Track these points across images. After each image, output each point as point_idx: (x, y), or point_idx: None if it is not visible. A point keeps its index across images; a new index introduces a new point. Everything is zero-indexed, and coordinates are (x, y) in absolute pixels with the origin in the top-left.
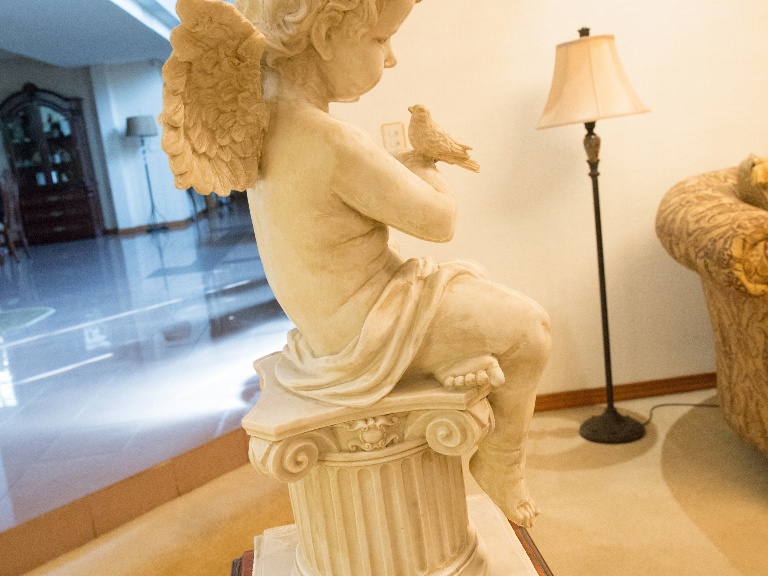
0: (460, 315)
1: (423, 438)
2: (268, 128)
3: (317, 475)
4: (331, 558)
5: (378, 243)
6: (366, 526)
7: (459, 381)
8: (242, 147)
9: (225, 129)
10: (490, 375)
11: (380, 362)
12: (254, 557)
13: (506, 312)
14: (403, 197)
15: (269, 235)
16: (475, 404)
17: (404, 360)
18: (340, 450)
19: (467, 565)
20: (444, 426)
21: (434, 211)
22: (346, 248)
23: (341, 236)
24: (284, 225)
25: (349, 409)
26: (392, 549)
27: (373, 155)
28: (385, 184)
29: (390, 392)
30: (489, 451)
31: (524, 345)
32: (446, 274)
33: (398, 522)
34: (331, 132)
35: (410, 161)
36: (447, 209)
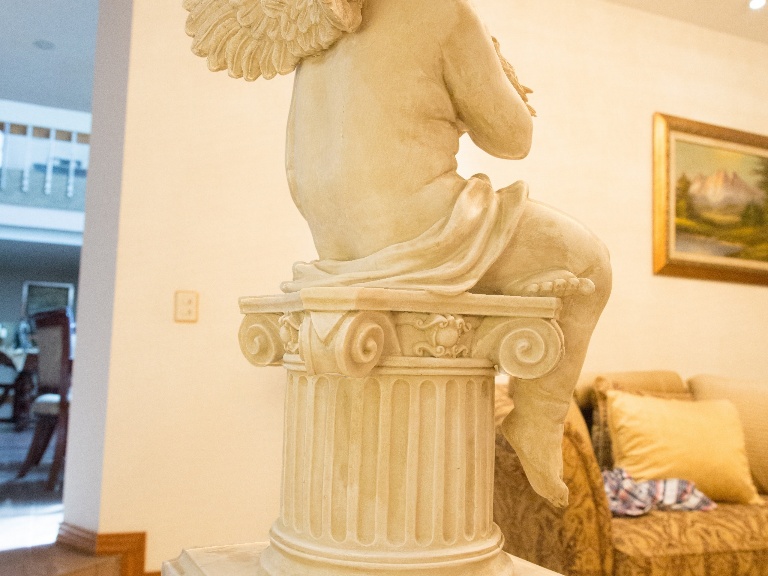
0: (545, 221)
1: (488, 360)
2: None
3: (362, 391)
4: (360, 510)
5: None
6: (419, 460)
7: (548, 285)
8: None
9: None
10: (581, 281)
11: (466, 250)
12: (175, 575)
13: (584, 231)
14: (503, 86)
15: (352, 96)
16: None
17: (492, 253)
18: (403, 355)
19: None
20: (524, 338)
21: (524, 114)
22: (438, 125)
23: (437, 109)
24: (379, 82)
25: (431, 295)
26: (444, 496)
27: (487, 30)
28: (492, 65)
29: None
30: (537, 401)
31: (598, 270)
32: None
33: (454, 460)
34: None
35: None
36: None
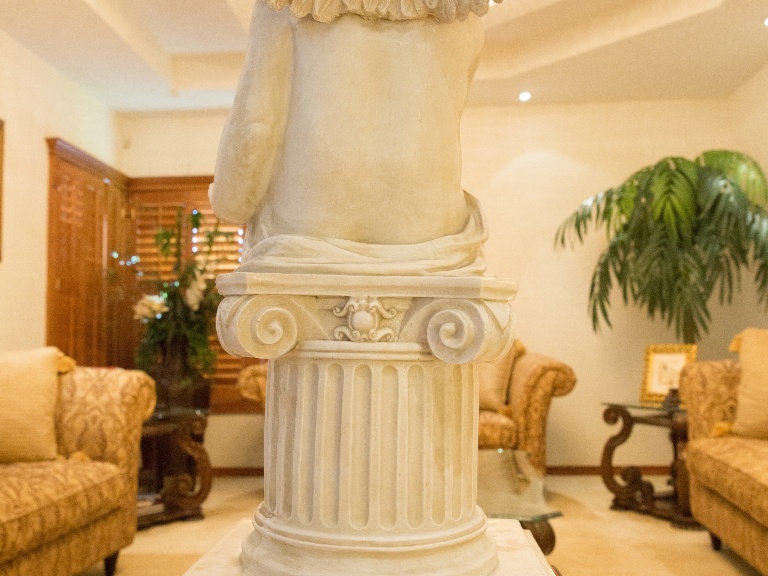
0: None
1: None
2: None
3: (452, 376)
4: None
5: None
6: None
7: None
8: None
9: None
10: None
11: (479, 247)
12: None
13: None
14: None
15: (432, 84)
16: None
17: None
18: None
19: None
20: None
21: None
22: None
23: None
24: (452, 79)
25: None
26: None
27: None
28: None
29: None
30: None
31: None
32: None
33: None
34: None
35: None
36: None
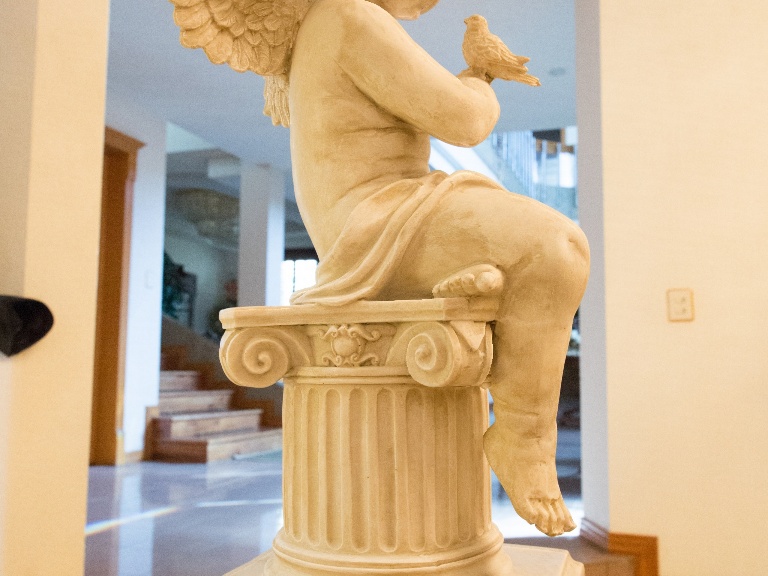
0: (461, 212)
1: None
2: (302, 20)
3: (293, 399)
4: (294, 508)
5: (397, 143)
6: (328, 465)
7: (443, 284)
8: (274, 37)
9: (259, 17)
10: (477, 276)
11: (364, 258)
12: None
13: (519, 215)
14: (416, 79)
15: None
16: (464, 321)
17: (388, 257)
18: (314, 365)
19: (456, 565)
20: (424, 344)
21: (452, 99)
22: (354, 137)
23: (349, 122)
24: (299, 113)
25: (321, 307)
26: (353, 503)
27: (385, 29)
28: (395, 62)
29: (373, 299)
30: (499, 411)
31: (538, 258)
32: (459, 173)
33: (365, 469)
34: (344, 5)
35: (460, 75)
36: (470, 101)
